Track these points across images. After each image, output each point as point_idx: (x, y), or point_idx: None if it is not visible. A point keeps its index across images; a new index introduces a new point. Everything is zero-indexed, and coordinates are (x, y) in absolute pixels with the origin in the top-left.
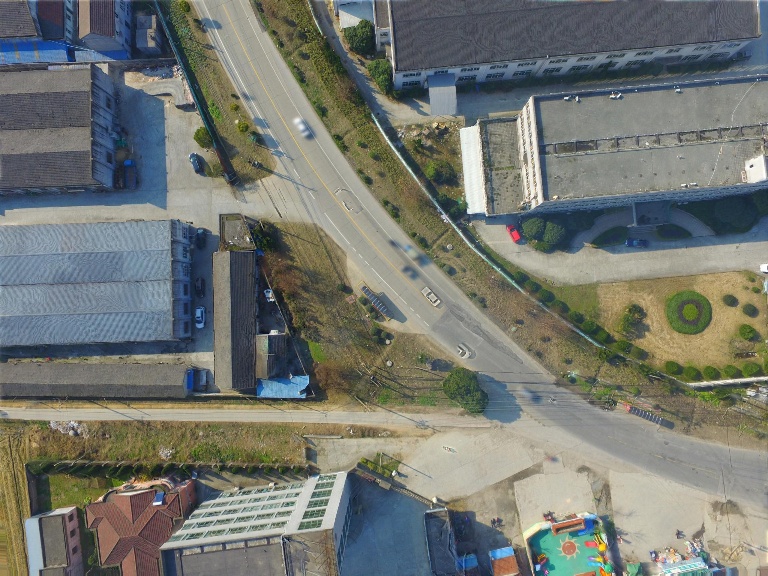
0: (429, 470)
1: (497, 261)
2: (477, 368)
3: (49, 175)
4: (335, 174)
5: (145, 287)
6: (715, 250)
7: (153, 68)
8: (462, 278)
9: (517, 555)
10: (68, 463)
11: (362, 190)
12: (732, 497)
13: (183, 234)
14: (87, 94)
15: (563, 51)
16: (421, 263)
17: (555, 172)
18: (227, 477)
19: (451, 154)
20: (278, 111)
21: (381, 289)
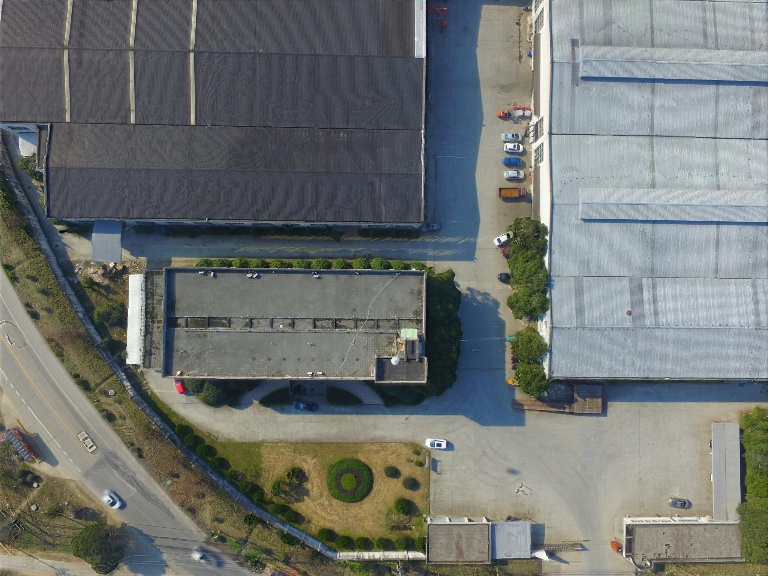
0: None
1: (162, 410)
2: (126, 519)
3: None
4: (1, 305)
5: None
6: (384, 419)
7: None
8: (121, 426)
9: None
10: None
11: (28, 324)
12: None
13: None
14: None
15: (223, 215)
16: (81, 406)
17: (183, 346)
18: None
19: (128, 295)
20: None
21: (35, 429)
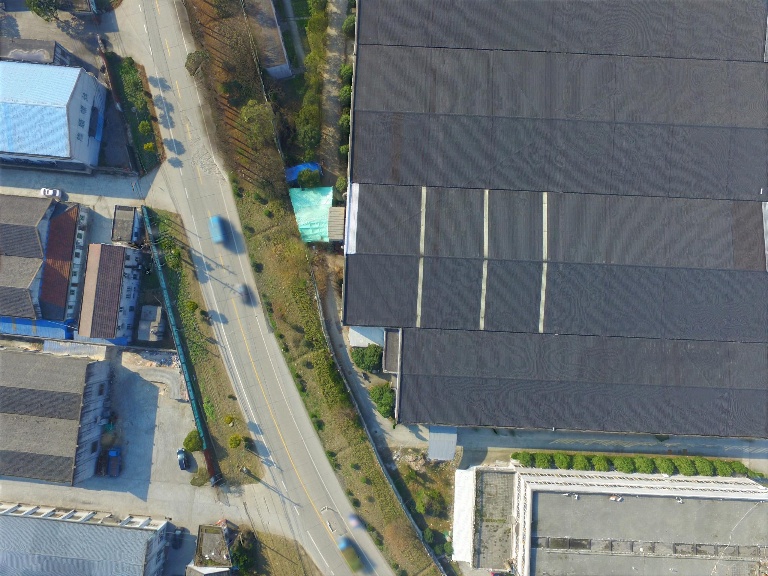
0: None
1: None
2: None
3: (29, 469)
4: (323, 491)
5: None
6: None
7: (152, 352)
8: None
9: None
10: None
11: (349, 512)
12: None
13: (159, 539)
14: (79, 396)
15: None
16: None
17: (544, 568)
18: None
19: (444, 484)
20: (274, 418)
21: None
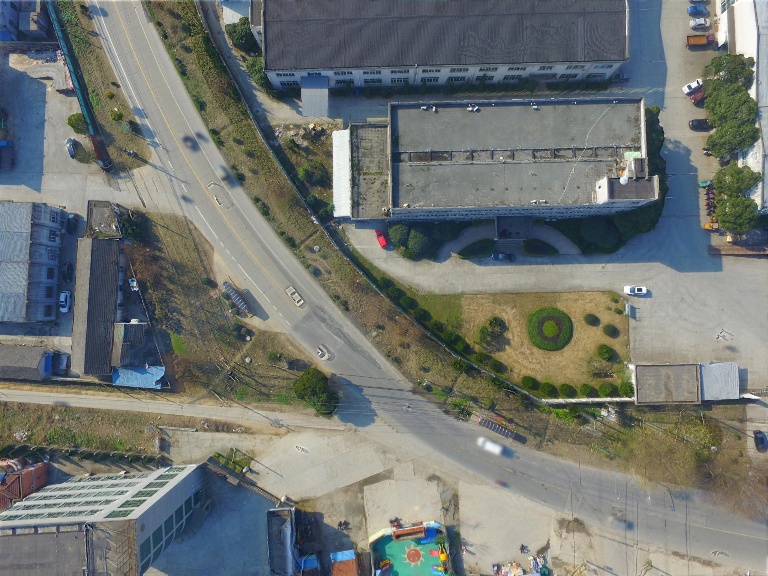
0: (281, 469)
1: (364, 265)
2: (335, 370)
3: None
4: (209, 168)
5: (5, 268)
6: (581, 269)
7: (38, 51)
8: (327, 280)
9: (361, 559)
10: None
11: (235, 186)
12: (579, 515)
13: (51, 218)
14: None
15: (432, 61)
16: (288, 262)
17: (408, 180)
18: (80, 462)
19: (326, 156)
20: (157, 102)
21: (246, 285)
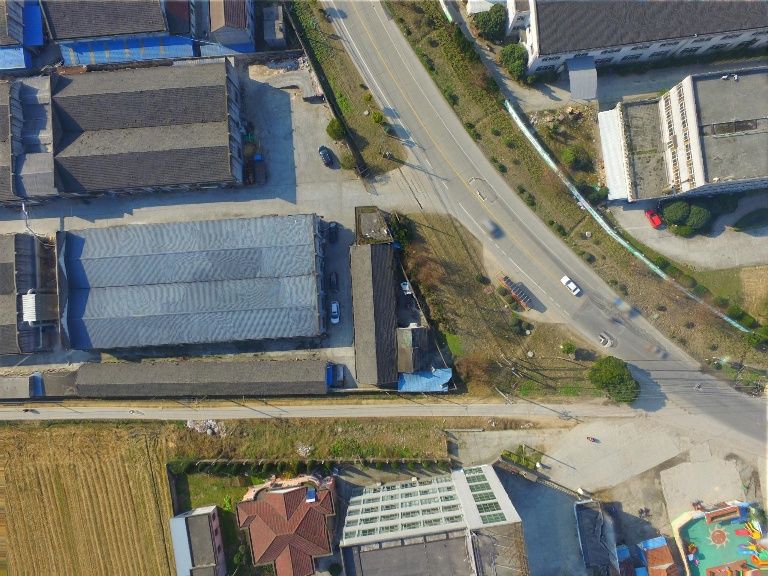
0: (573, 461)
1: (636, 247)
2: (620, 357)
3: (184, 172)
4: (468, 163)
5: (286, 283)
6: None
7: (277, 60)
8: (602, 265)
9: None
10: (208, 462)
11: (496, 179)
12: None
13: (318, 228)
14: (222, 88)
15: (712, 29)
16: (559, 251)
17: (714, 153)
18: (368, 473)
19: (585, 139)
20: (408, 100)
21: (519, 279)
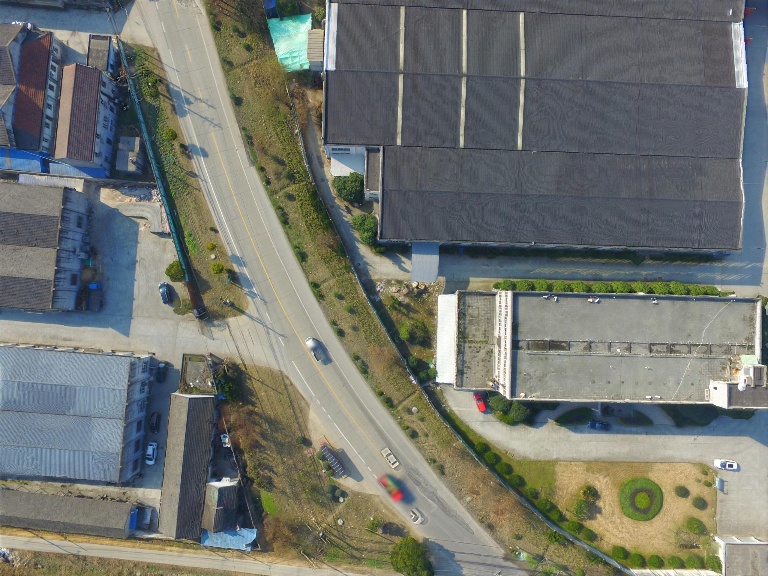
0: None
1: (460, 428)
2: (428, 535)
3: (6, 296)
4: (308, 322)
5: (95, 426)
6: (673, 440)
7: (132, 187)
8: (423, 443)
9: None
10: None
11: (333, 342)
12: None
13: (143, 369)
14: (56, 219)
15: (549, 239)
16: (384, 423)
17: (525, 369)
18: None
19: (427, 314)
20: (257, 250)
21: (341, 445)
